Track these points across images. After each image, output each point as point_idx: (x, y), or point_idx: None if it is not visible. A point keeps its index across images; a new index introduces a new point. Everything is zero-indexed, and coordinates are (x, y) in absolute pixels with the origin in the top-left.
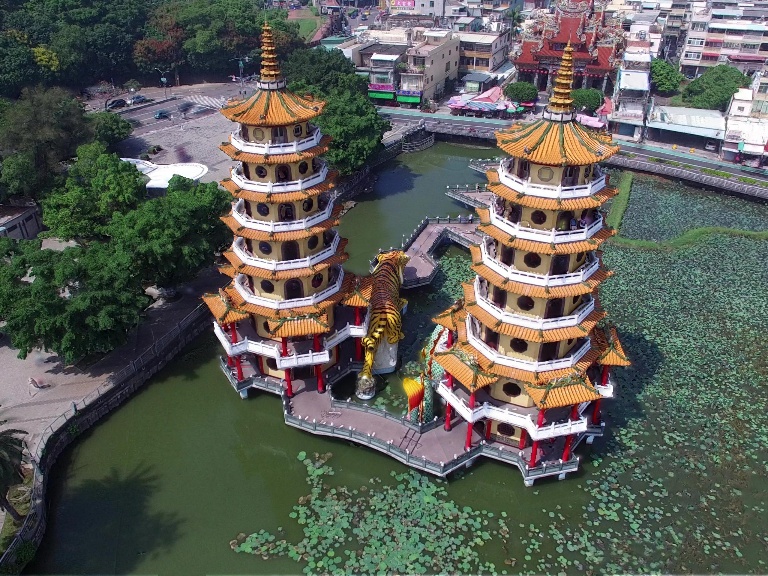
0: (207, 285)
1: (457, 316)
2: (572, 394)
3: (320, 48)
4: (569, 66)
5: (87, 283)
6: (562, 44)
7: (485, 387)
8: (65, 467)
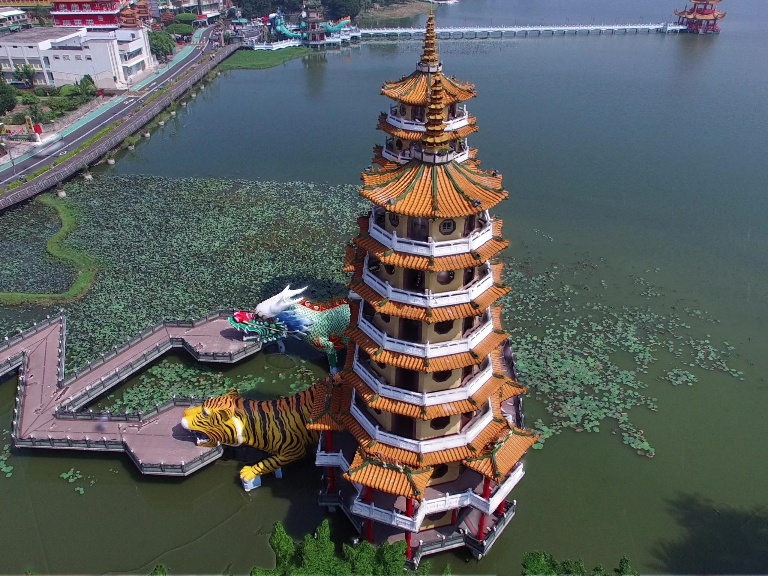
0: None
1: None
2: None
3: None
4: None
5: None
6: None
7: None
8: None
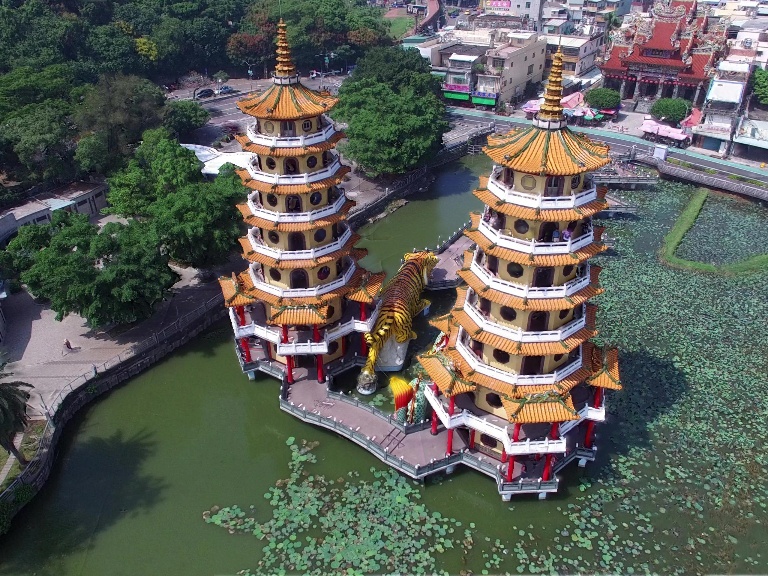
0: (242, 269)
1: (454, 321)
2: (548, 411)
3: (397, 46)
4: (558, 72)
5: (116, 257)
6: (654, 50)
7: (471, 395)
8: (79, 423)
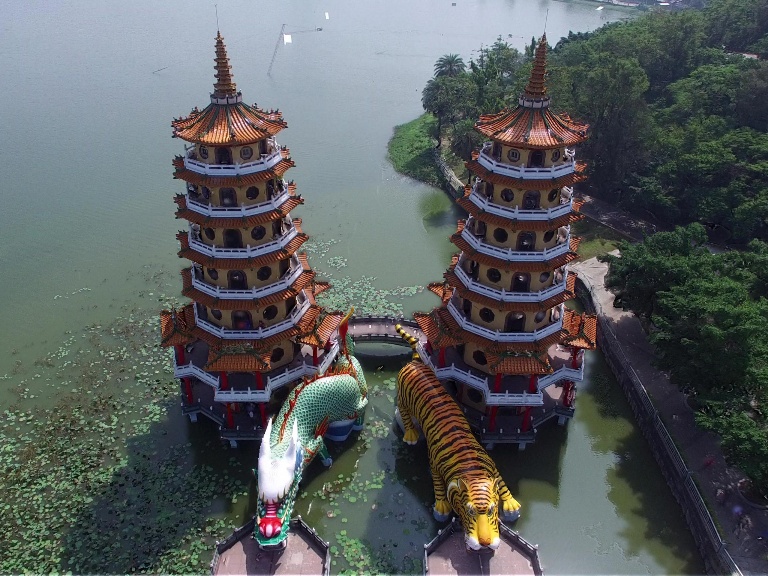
0: (699, 438)
1: None
2: None
3: None
4: None
5: None
6: None
7: None
8: None
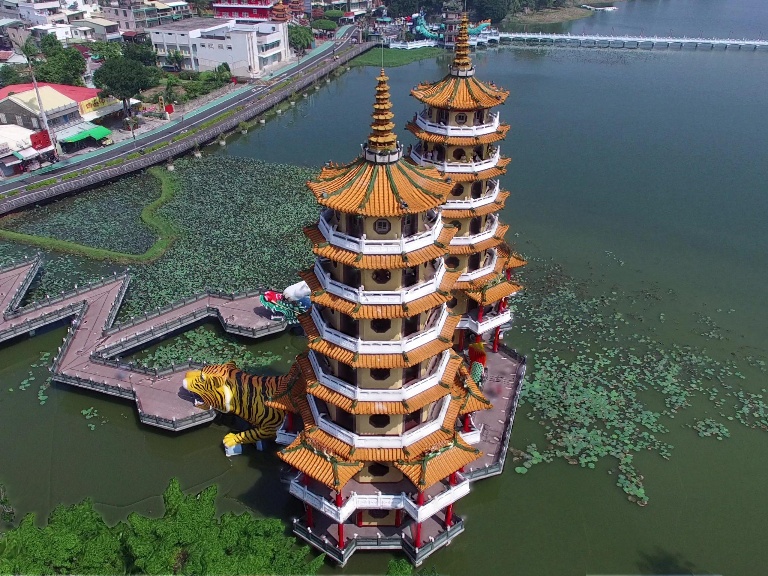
0: None
1: None
2: None
3: None
4: None
5: None
6: None
7: None
8: None
